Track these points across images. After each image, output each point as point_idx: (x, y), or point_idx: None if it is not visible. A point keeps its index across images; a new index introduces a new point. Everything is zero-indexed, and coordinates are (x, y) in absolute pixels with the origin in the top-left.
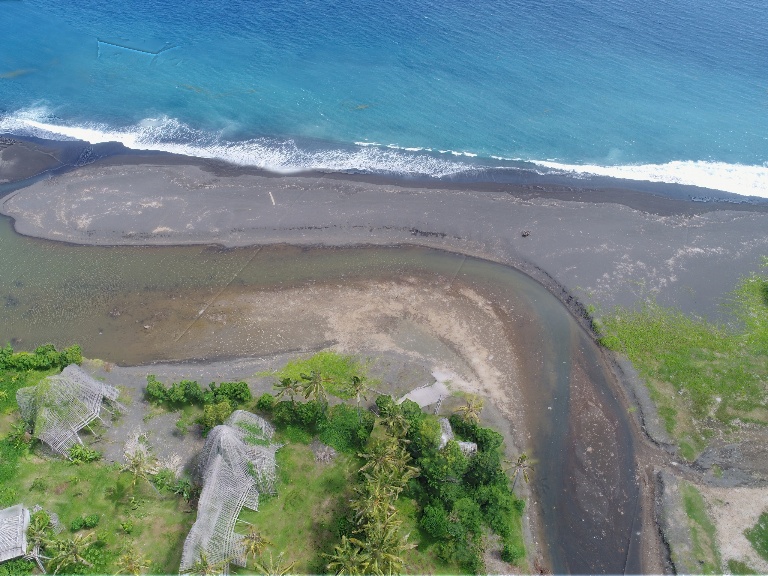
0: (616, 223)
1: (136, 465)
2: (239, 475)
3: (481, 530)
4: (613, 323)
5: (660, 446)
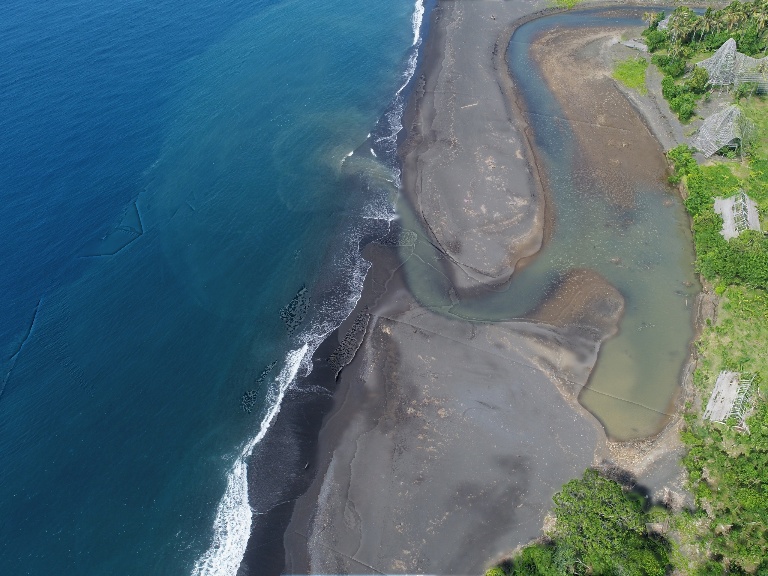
0: None
1: None
2: None
3: None
4: (558, 2)
5: (626, 0)
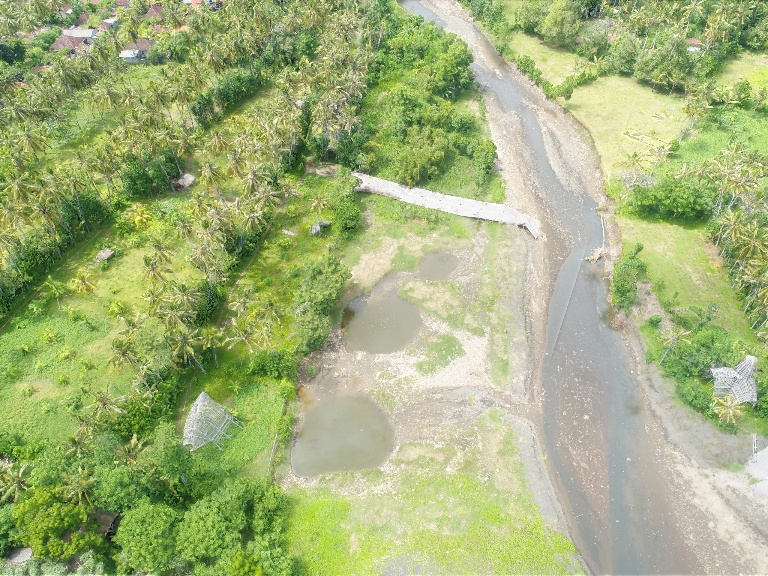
0: None
1: None
2: None
3: None
4: (561, 575)
5: None
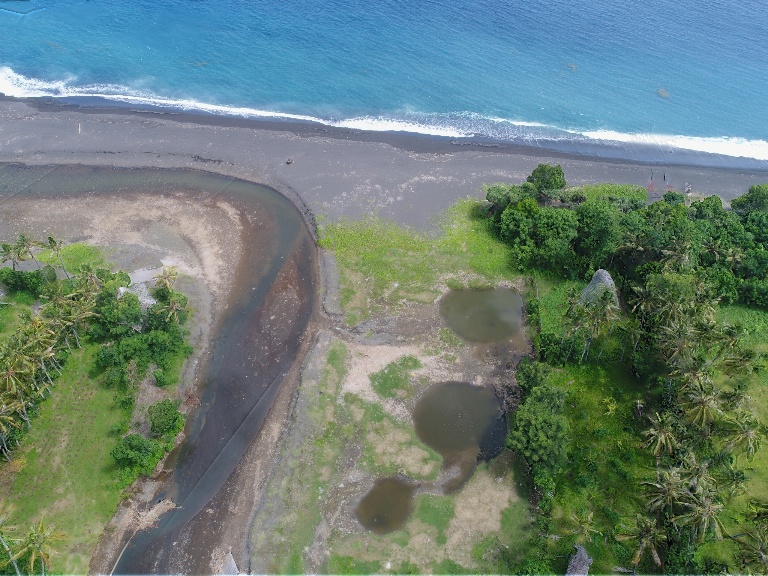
0: (372, 156)
1: None
2: None
3: (148, 366)
4: (333, 229)
5: (331, 316)
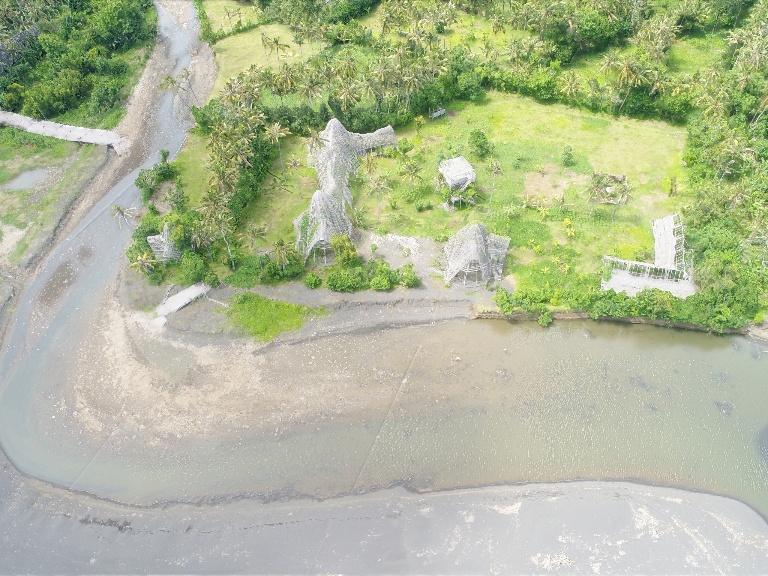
0: None
1: None
2: None
3: None
4: None
5: (11, 284)
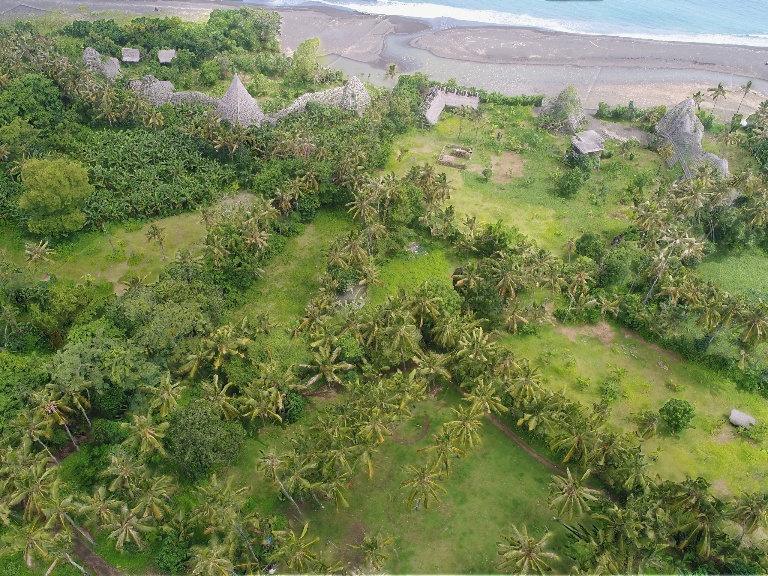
0: None
1: (652, 112)
2: (692, 129)
3: None
4: None
5: None
